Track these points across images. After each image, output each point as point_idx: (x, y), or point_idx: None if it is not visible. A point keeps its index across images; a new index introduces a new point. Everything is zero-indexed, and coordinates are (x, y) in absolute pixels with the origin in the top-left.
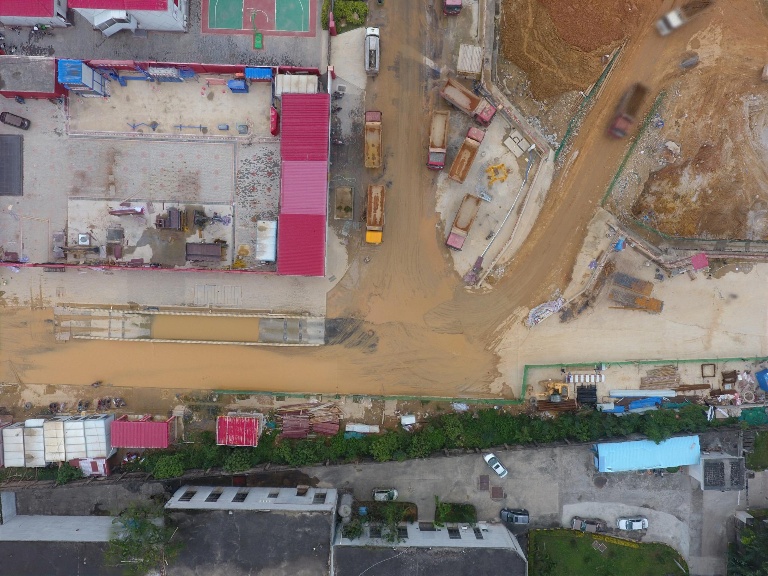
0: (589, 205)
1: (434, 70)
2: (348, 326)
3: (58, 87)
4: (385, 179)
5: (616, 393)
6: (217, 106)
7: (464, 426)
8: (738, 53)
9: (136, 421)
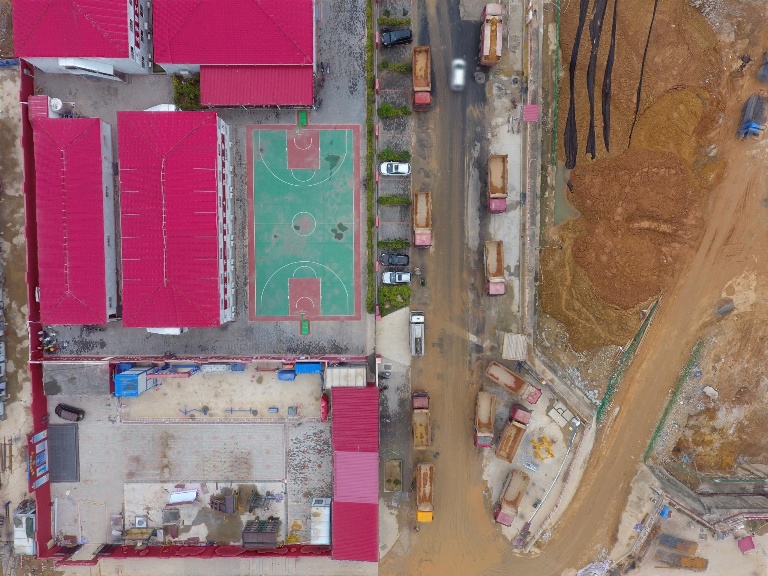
0: (631, 461)
1: (477, 345)
2: None
3: (112, 386)
4: (432, 450)
5: None
6: (266, 389)
7: None
8: None
9: None
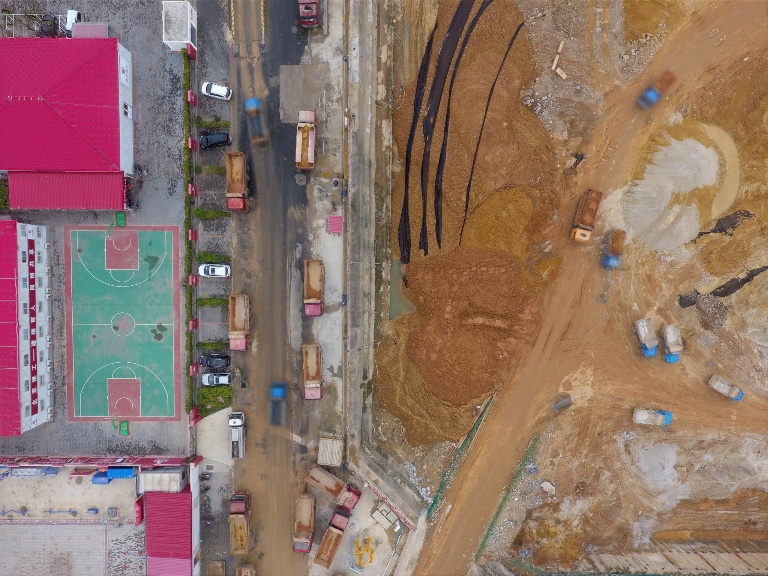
0: (463, 560)
1: (301, 445)
2: None
3: None
4: (256, 551)
5: None
6: (86, 490)
7: None
8: (610, 393)
9: None
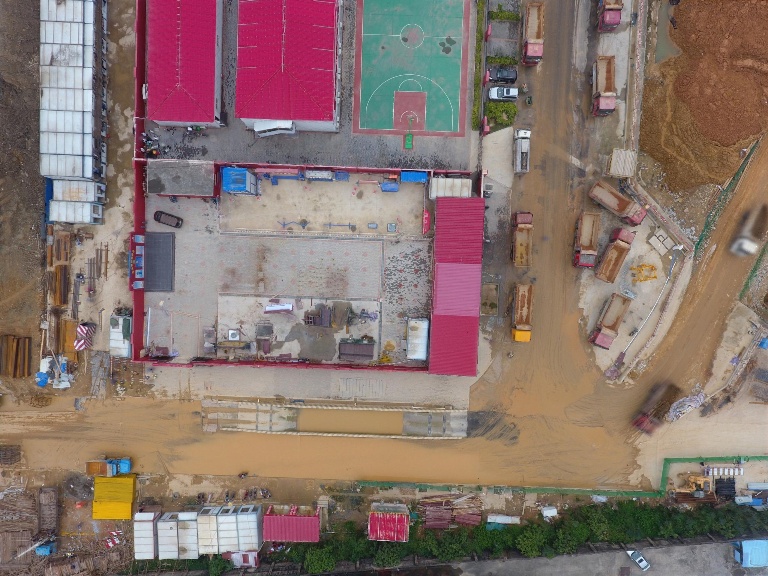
0: (727, 299)
1: (580, 169)
2: (490, 419)
3: (215, 189)
4: (529, 275)
5: (754, 486)
6: (366, 204)
7: (607, 520)
8: None
9: (288, 515)
